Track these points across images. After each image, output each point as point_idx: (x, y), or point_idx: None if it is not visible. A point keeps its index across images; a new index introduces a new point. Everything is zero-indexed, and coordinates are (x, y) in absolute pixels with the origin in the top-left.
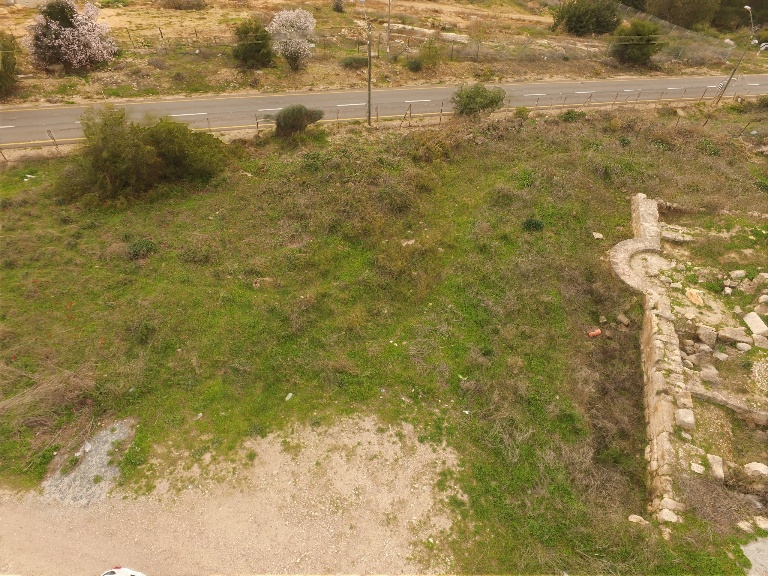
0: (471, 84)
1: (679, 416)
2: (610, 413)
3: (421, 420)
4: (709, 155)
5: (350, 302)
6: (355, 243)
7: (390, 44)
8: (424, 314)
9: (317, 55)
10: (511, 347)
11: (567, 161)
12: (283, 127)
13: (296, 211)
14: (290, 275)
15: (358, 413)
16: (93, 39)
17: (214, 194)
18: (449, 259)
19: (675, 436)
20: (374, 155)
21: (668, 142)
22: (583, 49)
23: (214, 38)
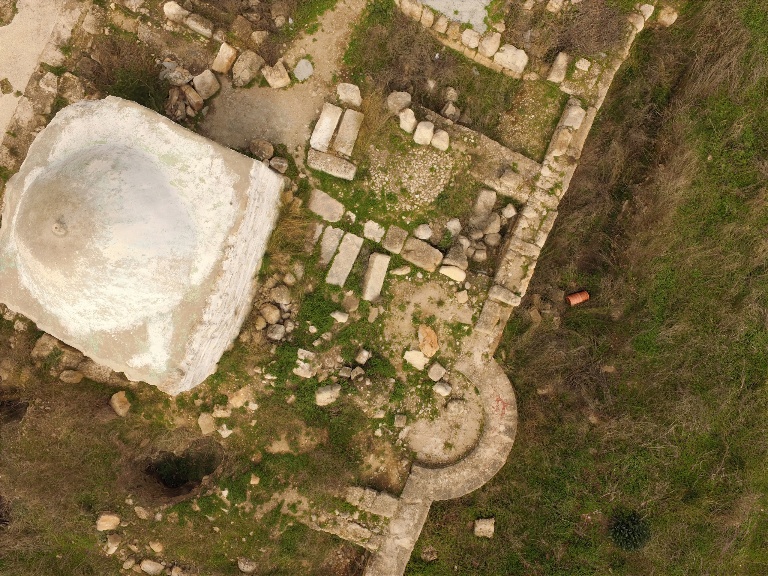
0: None
1: None
2: None
3: None
4: None
5: None
6: None
7: None
8: None
9: None
10: None
11: None
12: None
13: None
14: None
15: None
16: None
17: None
18: None
19: (588, 103)
20: None
21: None
22: None
23: None
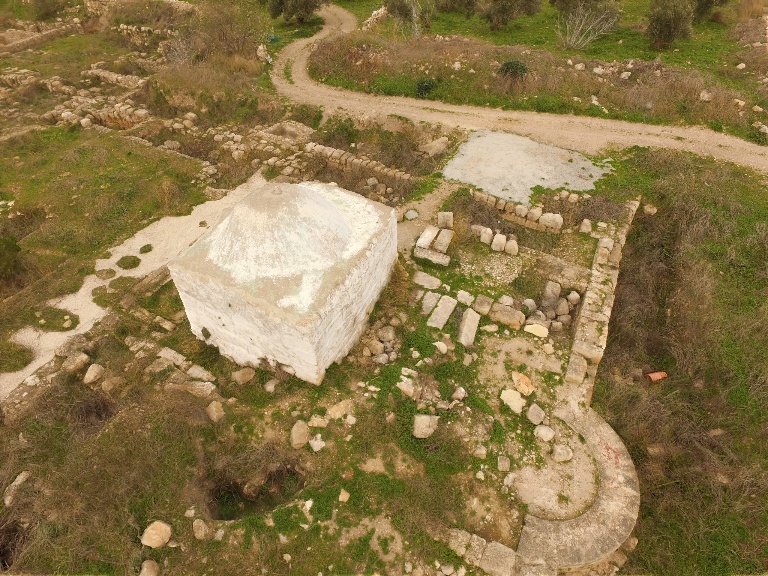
0: None
1: None
2: None
3: None
4: None
5: None
6: None
7: None
8: None
9: None
10: None
11: None
12: None
13: None
14: None
15: None
16: None
17: None
18: None
19: (614, 242)
20: None
21: None
22: None
23: None
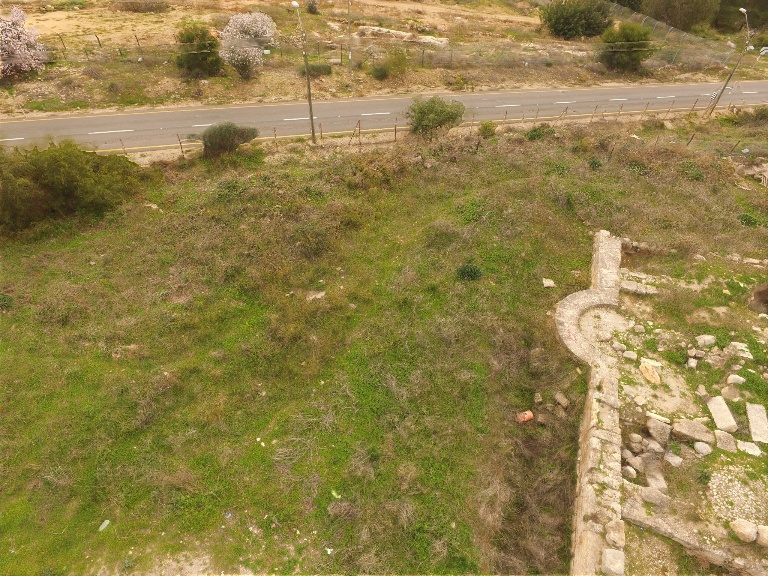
0: (439, 94)
1: (605, 561)
2: (524, 542)
3: (266, 564)
4: (690, 180)
5: (223, 381)
6: (252, 297)
7: (360, 49)
8: (310, 398)
9: (275, 62)
10: (408, 447)
11: (524, 189)
12: (211, 147)
13: (192, 255)
14: (160, 342)
15: (187, 552)
16: (18, 47)
17: (107, 231)
18: (360, 318)
19: None
20: (303, 182)
21: (644, 165)
22: (569, 53)
23: (119, 50)
